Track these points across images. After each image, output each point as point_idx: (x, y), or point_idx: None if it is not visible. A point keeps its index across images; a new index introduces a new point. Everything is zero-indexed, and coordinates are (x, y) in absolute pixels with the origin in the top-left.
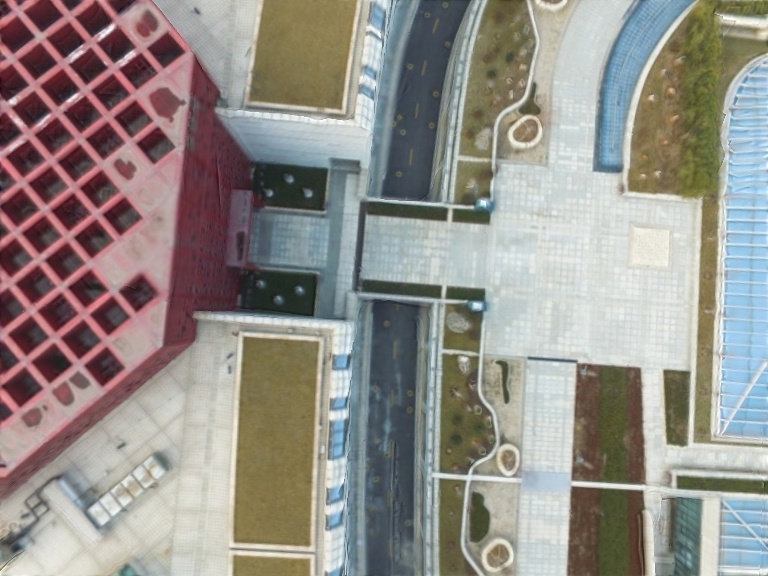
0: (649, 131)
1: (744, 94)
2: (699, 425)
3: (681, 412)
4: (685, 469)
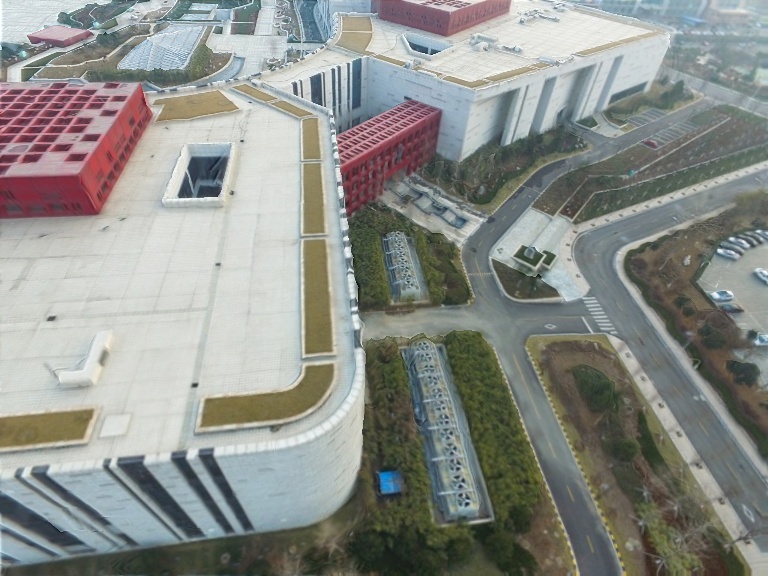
0: (222, 61)
1: (177, 66)
2: (211, 27)
3: (217, 29)
4: (218, 23)
